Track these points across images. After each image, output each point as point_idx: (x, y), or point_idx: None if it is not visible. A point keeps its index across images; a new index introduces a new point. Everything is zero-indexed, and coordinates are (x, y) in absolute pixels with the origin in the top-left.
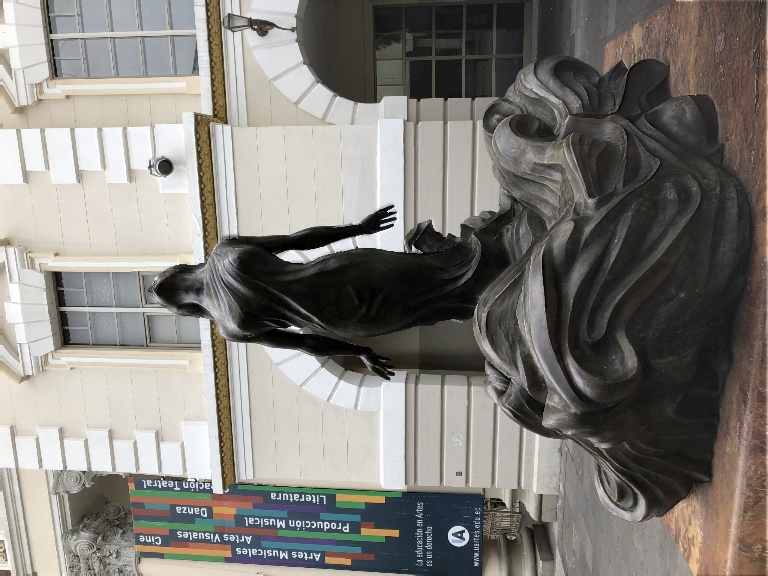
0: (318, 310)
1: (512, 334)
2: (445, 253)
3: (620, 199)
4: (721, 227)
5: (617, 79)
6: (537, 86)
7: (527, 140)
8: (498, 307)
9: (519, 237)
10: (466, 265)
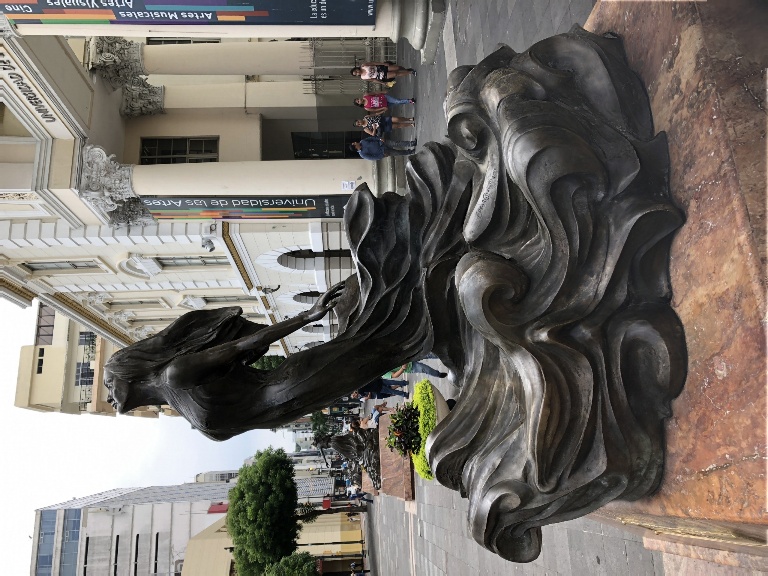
0: None
1: (456, 479)
2: (397, 330)
3: (562, 496)
4: None
5: (623, 201)
6: (525, 191)
7: (498, 334)
8: (447, 461)
9: None
10: (418, 345)
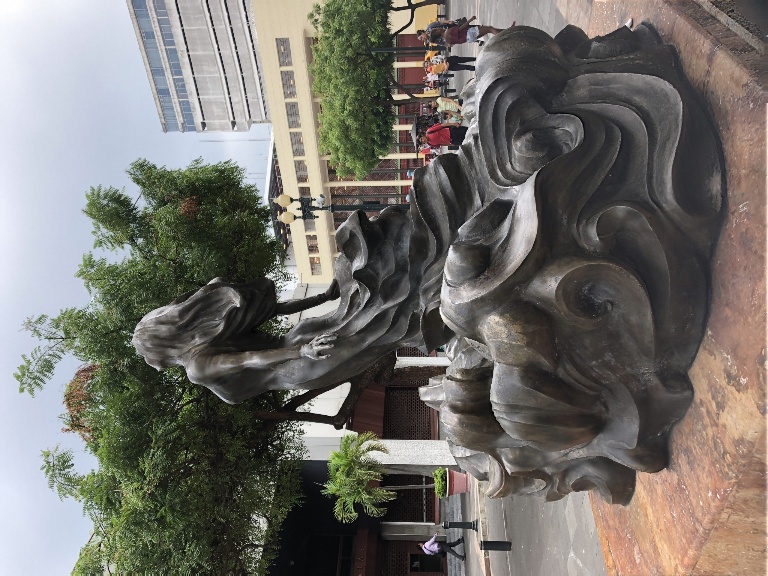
0: None
1: None
2: None
3: None
4: None
5: None
6: None
7: None
8: None
9: None
10: None
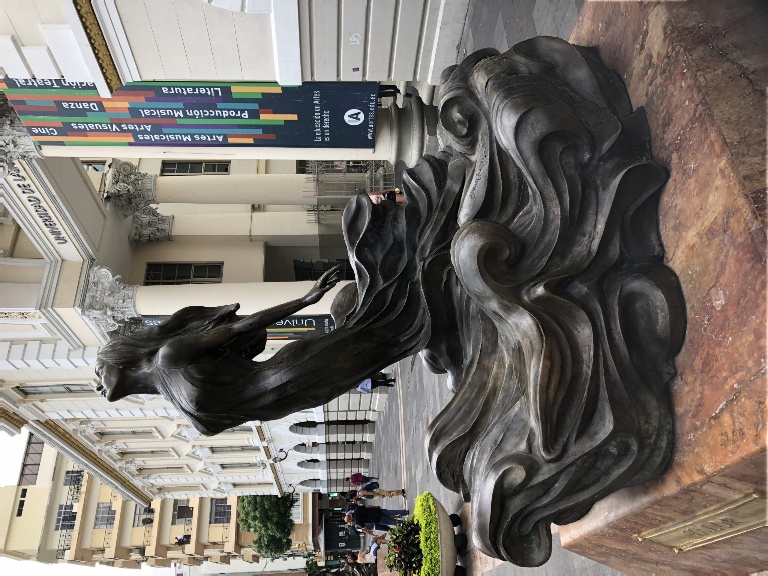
0: (280, 415)
1: (457, 476)
2: (394, 320)
3: (569, 463)
4: (643, 466)
5: (608, 162)
6: (515, 153)
7: (494, 293)
8: (448, 453)
9: (469, 312)
10: (415, 337)
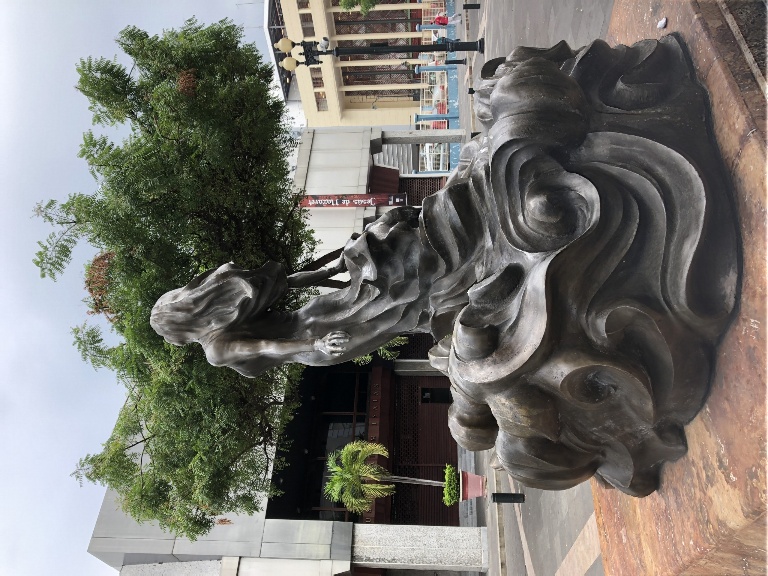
0: None
1: None
2: None
3: None
4: None
5: None
6: None
7: None
8: None
9: None
10: None
